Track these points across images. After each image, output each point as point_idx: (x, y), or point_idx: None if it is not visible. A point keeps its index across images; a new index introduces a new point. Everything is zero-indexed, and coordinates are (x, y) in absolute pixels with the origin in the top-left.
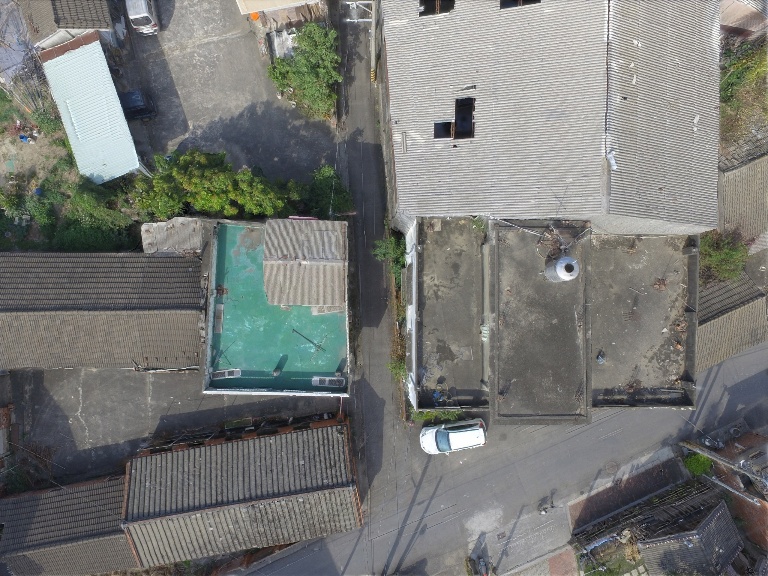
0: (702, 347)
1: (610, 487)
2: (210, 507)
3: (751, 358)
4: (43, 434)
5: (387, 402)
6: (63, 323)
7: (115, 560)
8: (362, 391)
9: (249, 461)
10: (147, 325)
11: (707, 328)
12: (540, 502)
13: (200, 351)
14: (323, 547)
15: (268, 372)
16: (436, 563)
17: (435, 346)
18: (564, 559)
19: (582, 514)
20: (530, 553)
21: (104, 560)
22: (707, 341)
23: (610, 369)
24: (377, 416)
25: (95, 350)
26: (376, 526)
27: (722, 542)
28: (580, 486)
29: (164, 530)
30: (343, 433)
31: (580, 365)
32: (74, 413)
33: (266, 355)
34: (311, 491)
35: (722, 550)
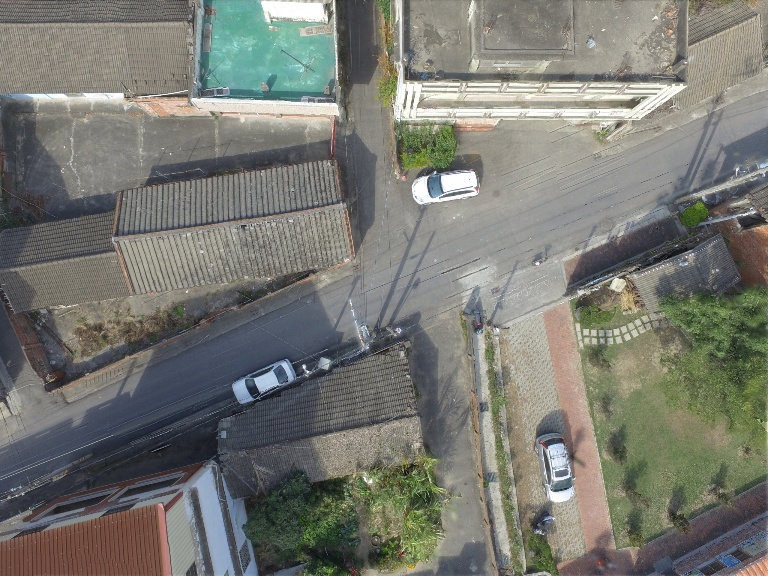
0: (696, 73)
1: (605, 244)
2: (200, 225)
3: (748, 117)
4: (35, 184)
5: (379, 157)
6: (52, 38)
7: (107, 285)
8: (353, 146)
9: (239, 190)
10: (135, 41)
11: (700, 50)
12: (534, 258)
13: (189, 69)
14: (316, 300)
15: (257, 91)
16: (430, 316)
17: (422, 30)
18: (559, 312)
19: (577, 269)
20: (525, 306)
21: (96, 285)
22: (701, 66)
23: (600, 55)
24: (369, 171)
25: (84, 71)
26: (369, 279)
27: (718, 268)
28: (575, 242)
29: (155, 250)
30: (333, 165)
31: (567, 2)
32: (66, 162)
33: (255, 74)
34: (301, 210)
35: (718, 269)
